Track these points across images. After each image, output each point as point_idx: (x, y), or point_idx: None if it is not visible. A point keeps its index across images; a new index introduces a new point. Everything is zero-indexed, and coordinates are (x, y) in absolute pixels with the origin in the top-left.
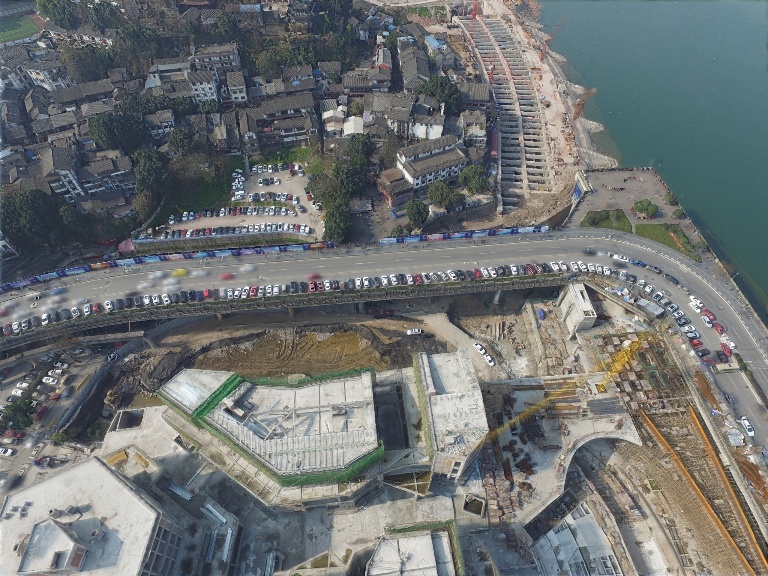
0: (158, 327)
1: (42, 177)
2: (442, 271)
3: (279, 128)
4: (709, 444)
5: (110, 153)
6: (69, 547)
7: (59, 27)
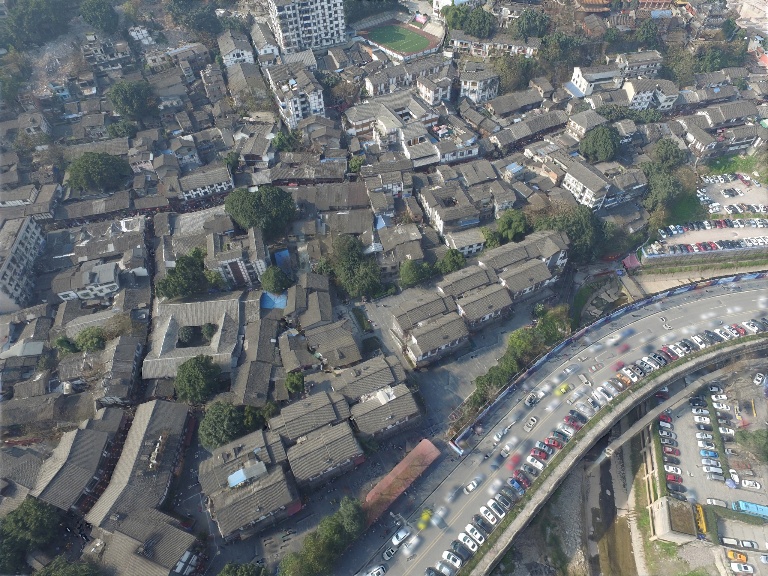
0: None
1: (567, 192)
2: None
3: (729, 137)
4: None
5: (608, 166)
6: None
7: (469, 36)
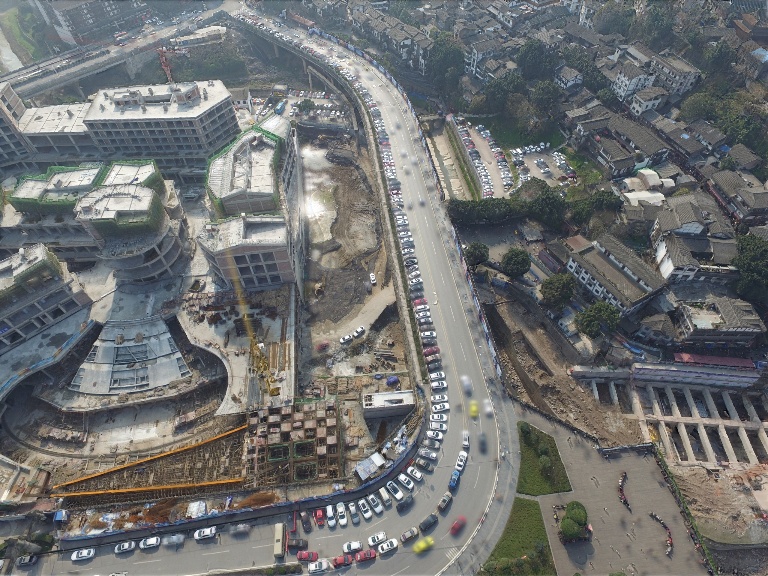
0: None
1: None
2: (422, 275)
3: None
4: (200, 484)
5: (513, 66)
6: (182, 92)
7: None
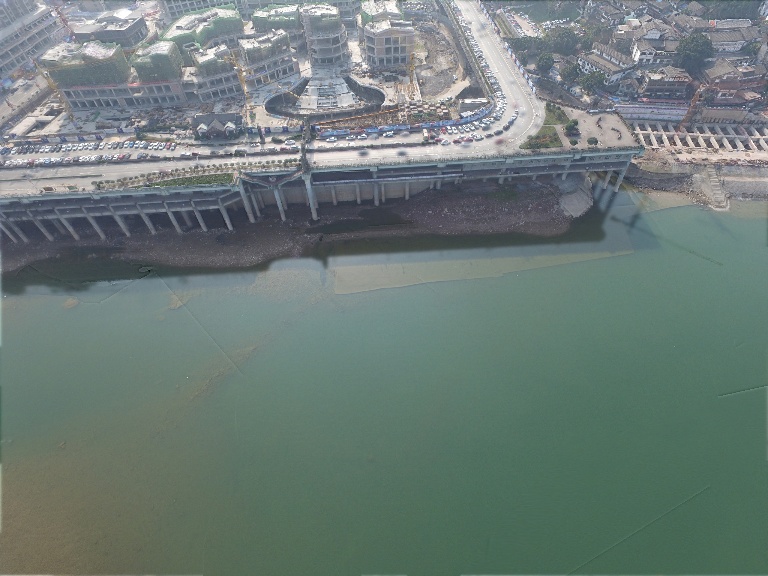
0: (445, 17)
1: None
2: (488, 62)
3: None
4: None
5: None
6: None
7: None
